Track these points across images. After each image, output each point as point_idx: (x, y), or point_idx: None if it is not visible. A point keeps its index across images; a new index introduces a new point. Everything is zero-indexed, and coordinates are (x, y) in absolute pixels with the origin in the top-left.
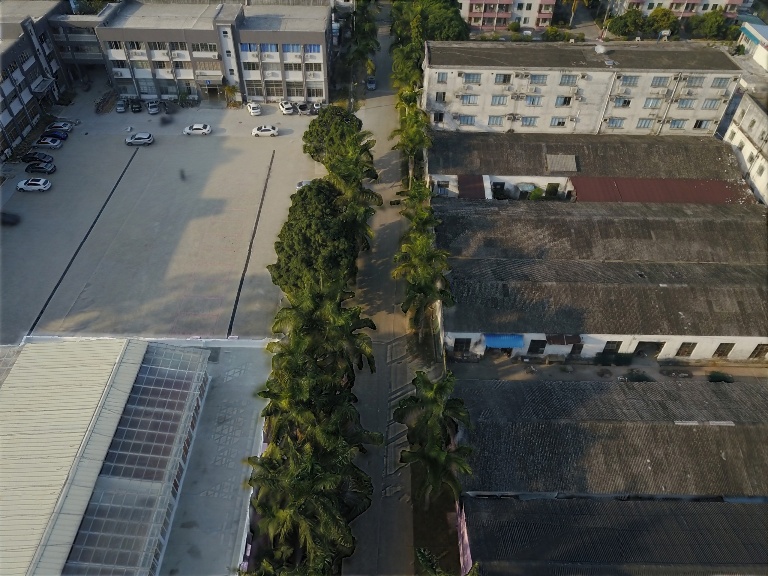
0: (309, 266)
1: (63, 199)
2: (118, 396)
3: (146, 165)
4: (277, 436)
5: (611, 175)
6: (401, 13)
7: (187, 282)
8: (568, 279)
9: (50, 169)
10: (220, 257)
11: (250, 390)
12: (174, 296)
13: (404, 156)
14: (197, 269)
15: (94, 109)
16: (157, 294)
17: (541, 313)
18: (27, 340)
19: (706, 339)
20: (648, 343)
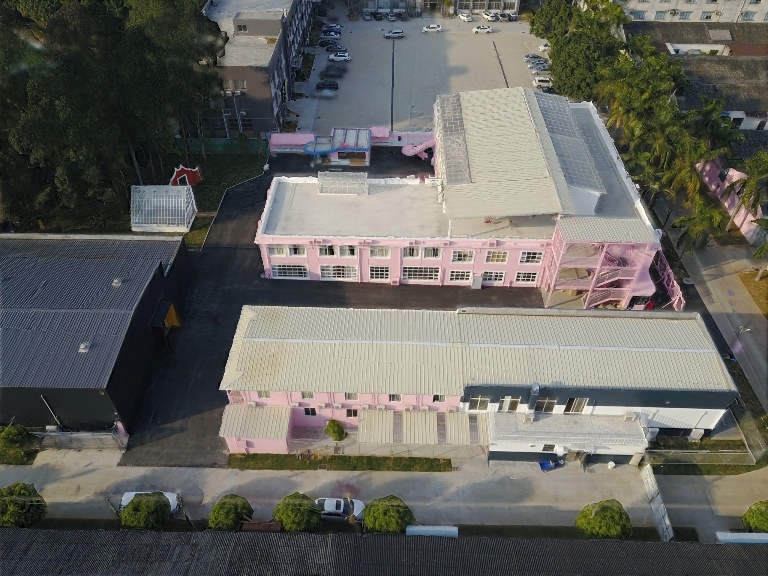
0: (591, 72)
1: (363, 66)
2: (535, 106)
3: (407, 49)
4: None
5: (757, 42)
6: None
7: None
8: None
9: (344, 49)
10: None
11: (585, 123)
12: None
13: None
14: None
15: (347, 18)
16: None
17: (740, 100)
18: None
19: None
20: None
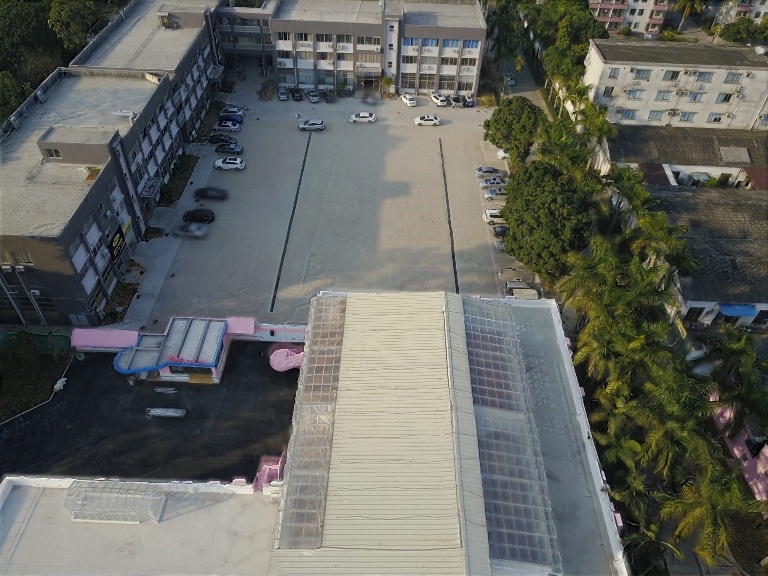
0: (556, 237)
1: (259, 178)
2: (459, 339)
3: (325, 149)
4: (620, 376)
5: None
6: (538, 14)
7: (404, 255)
8: None
9: (239, 150)
10: (426, 233)
11: (542, 343)
12: (397, 267)
13: None
14: (408, 243)
15: (257, 97)
16: (380, 264)
17: None
18: None
19: None
20: None
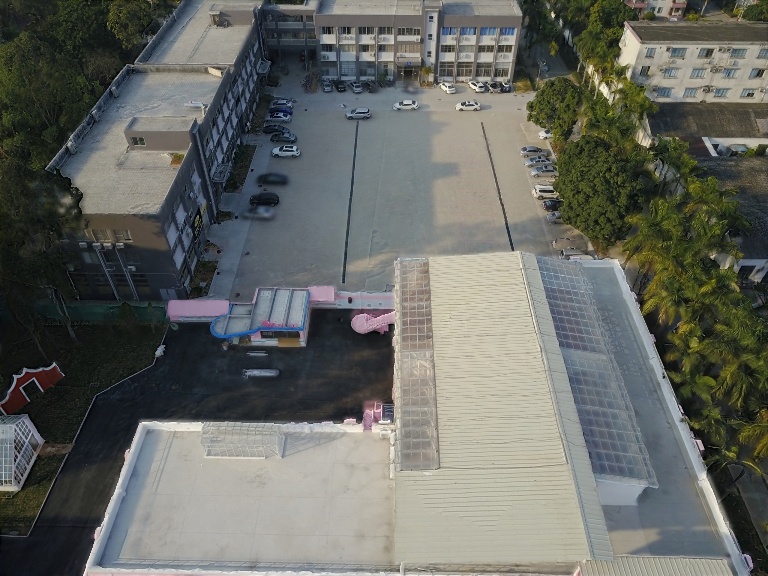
0: (612, 204)
1: (315, 163)
2: (538, 292)
3: (373, 135)
4: (691, 319)
5: None
6: (568, 1)
7: (461, 229)
8: None
9: (293, 138)
10: (479, 209)
11: (609, 298)
12: (455, 240)
13: None
14: (464, 219)
15: (302, 89)
16: (440, 238)
17: None
18: None
19: None
20: None
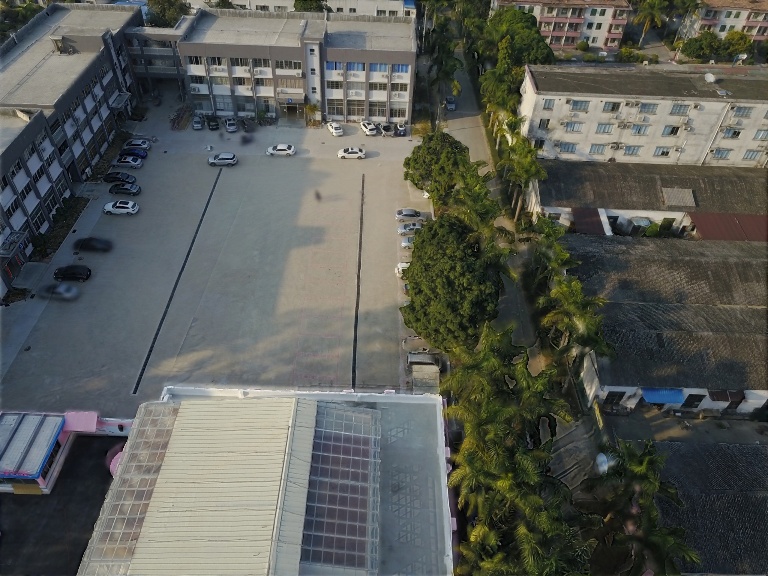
0: (455, 311)
1: (153, 223)
2: (300, 466)
3: (233, 188)
4: (487, 518)
5: (731, 211)
6: (481, 32)
7: (299, 318)
8: (723, 329)
9: (135, 190)
10: (329, 291)
11: (419, 453)
12: (289, 334)
13: (501, 183)
14: (307, 304)
15: (169, 125)
16: (270, 331)
17: (701, 366)
18: (168, 391)
19: None
20: None
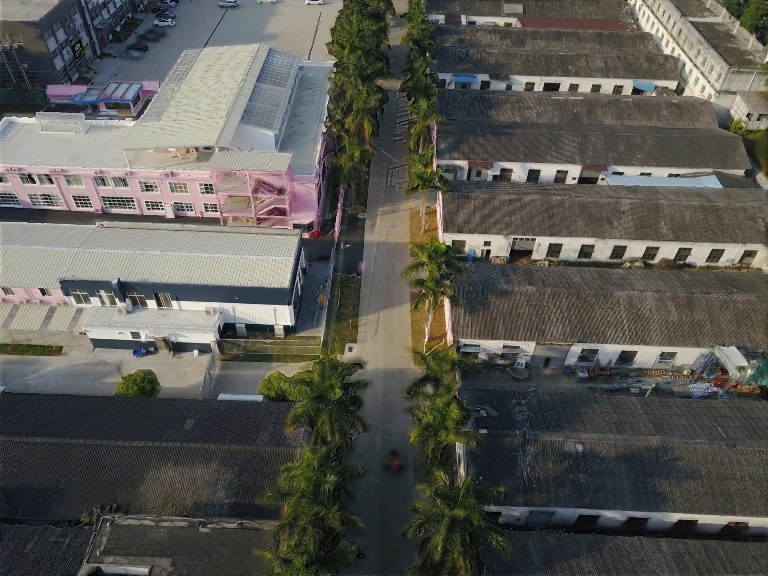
0: None
1: (184, 31)
2: (259, 60)
3: (235, 17)
4: (342, 71)
5: (546, 16)
6: None
7: None
8: None
9: (172, 16)
10: None
11: (322, 79)
12: None
13: None
14: None
15: None
16: None
17: (487, 64)
18: None
19: (584, 81)
20: (550, 84)
